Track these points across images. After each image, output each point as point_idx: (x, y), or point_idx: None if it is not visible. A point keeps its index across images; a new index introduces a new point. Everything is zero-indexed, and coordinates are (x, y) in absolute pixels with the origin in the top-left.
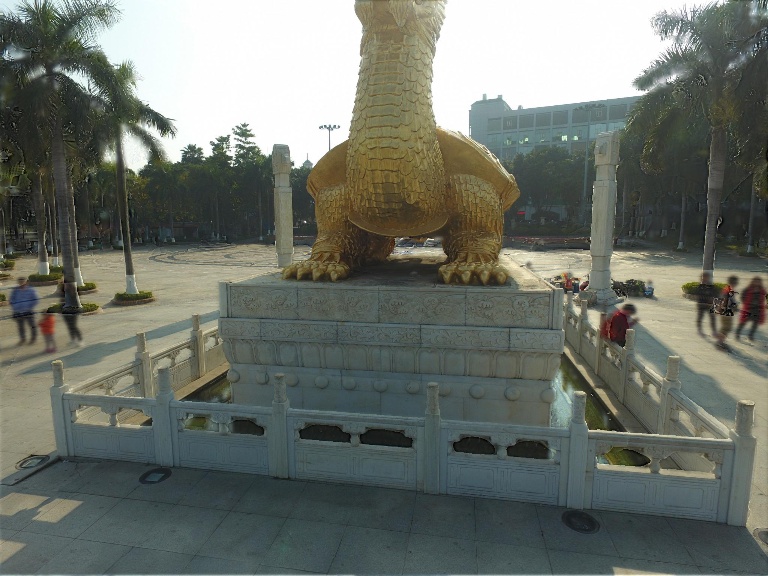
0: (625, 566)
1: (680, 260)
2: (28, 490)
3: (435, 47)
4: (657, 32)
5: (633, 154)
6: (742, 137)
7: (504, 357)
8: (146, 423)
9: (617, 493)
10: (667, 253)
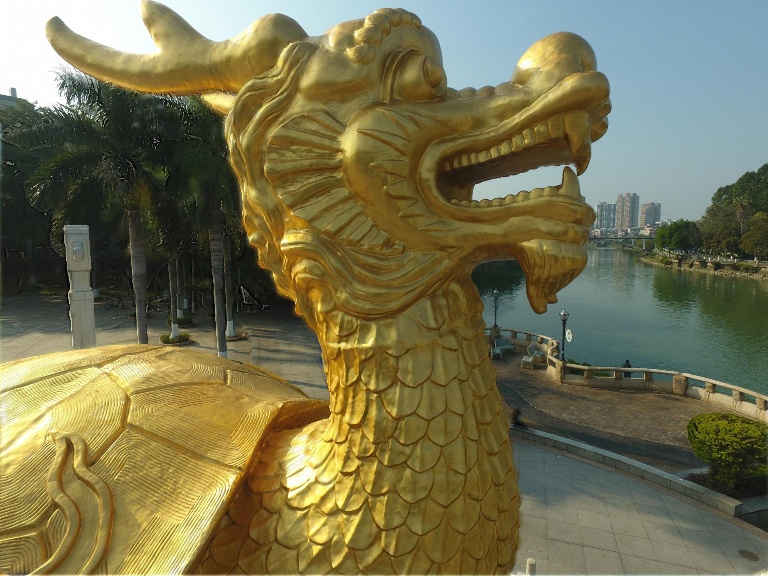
0: None
1: (18, 322)
2: None
3: None
4: (69, 94)
5: None
6: (164, 227)
7: None
8: None
9: None
10: None
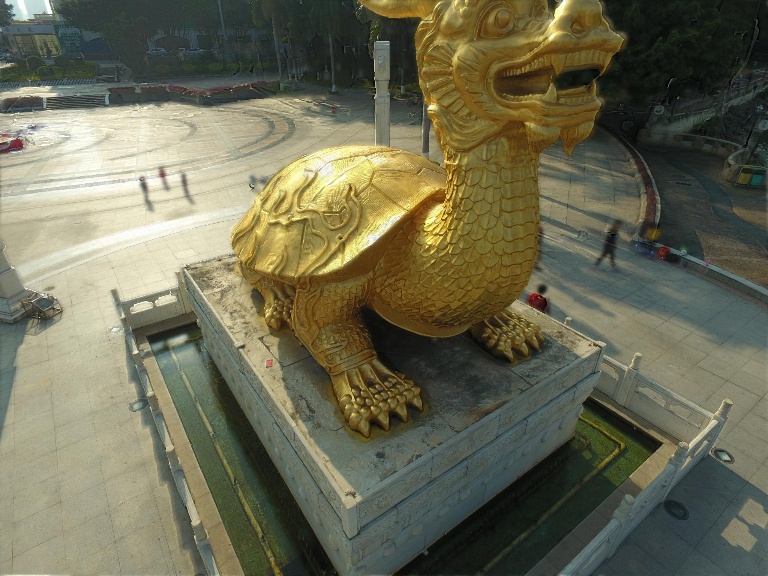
0: (722, 529)
1: (350, 111)
2: None
3: None
4: None
5: None
6: None
7: (567, 407)
8: None
9: (678, 478)
10: (326, 97)
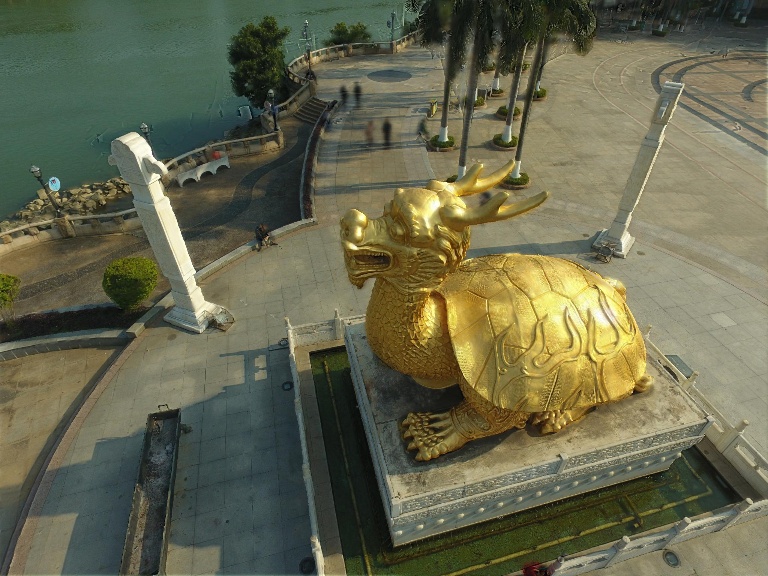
0: None
1: None
2: (268, 358)
3: (415, 293)
4: None
5: None
6: None
7: None
8: (326, 349)
9: None
10: None
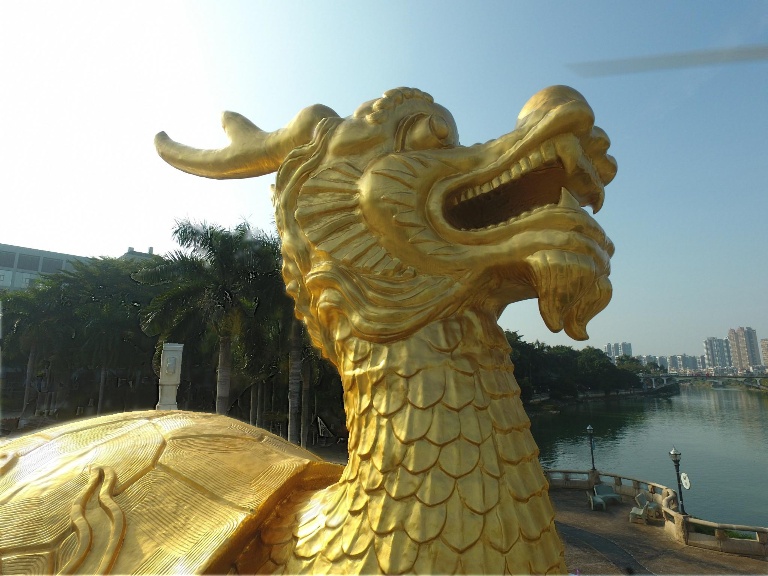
0: None
1: None
2: None
3: None
4: (188, 239)
5: (46, 318)
6: (250, 352)
7: None
8: None
9: None
10: None
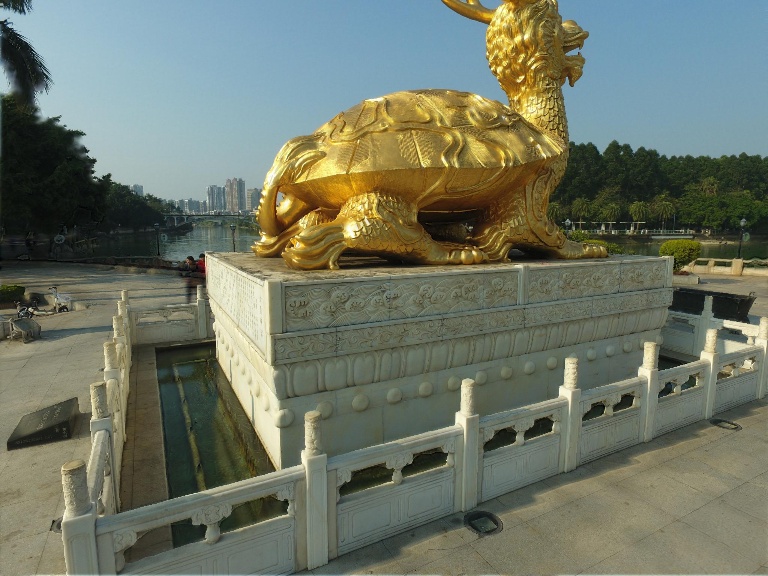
0: None
1: None
2: None
3: None
4: None
5: None
6: None
7: None
8: None
9: None
10: None
